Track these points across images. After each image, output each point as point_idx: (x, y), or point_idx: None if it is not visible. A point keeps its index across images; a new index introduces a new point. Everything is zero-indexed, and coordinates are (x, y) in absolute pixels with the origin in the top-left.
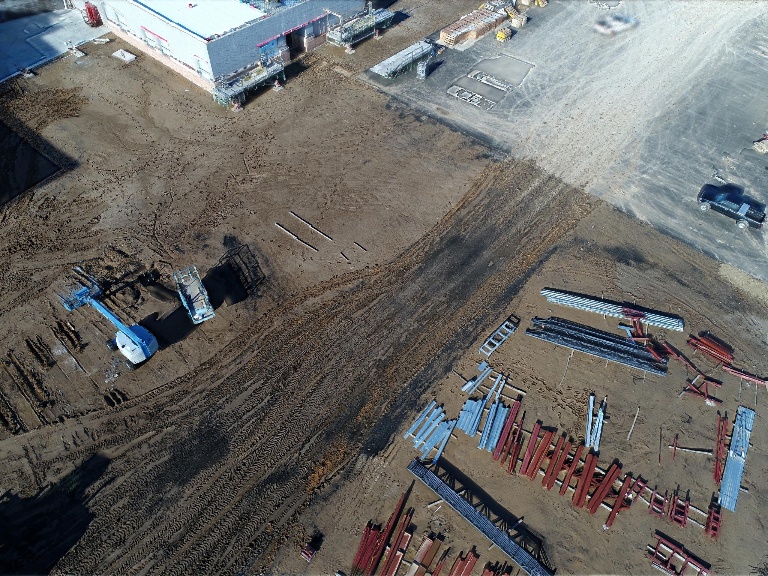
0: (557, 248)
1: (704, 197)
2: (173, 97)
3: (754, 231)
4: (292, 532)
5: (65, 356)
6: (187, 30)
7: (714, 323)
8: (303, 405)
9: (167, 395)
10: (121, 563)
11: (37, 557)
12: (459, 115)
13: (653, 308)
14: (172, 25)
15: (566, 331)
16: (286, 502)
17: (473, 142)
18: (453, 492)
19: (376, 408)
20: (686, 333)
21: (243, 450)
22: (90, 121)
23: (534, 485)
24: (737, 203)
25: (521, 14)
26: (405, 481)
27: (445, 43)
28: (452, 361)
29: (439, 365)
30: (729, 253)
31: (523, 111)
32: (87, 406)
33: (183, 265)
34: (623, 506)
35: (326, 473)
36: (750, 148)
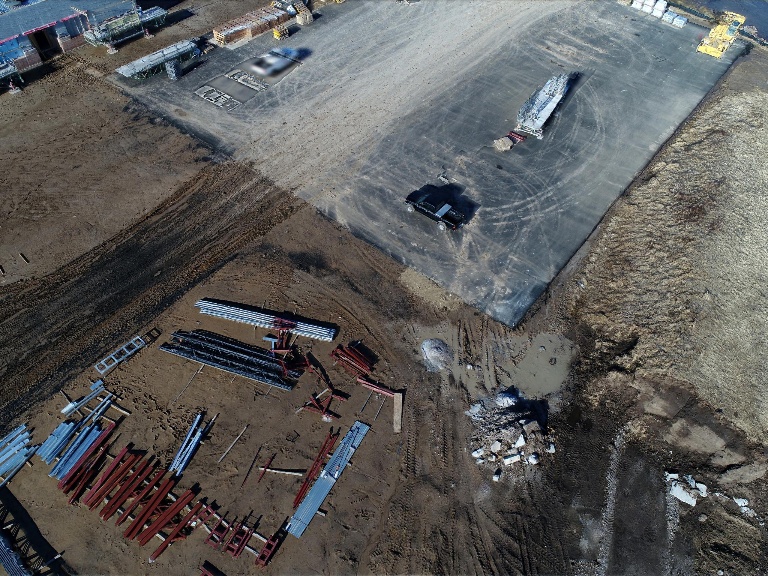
0: (237, 255)
1: (408, 198)
2: None
3: (456, 233)
4: None
5: None
6: None
7: (371, 332)
8: None
9: None
10: None
11: None
12: (196, 116)
13: (312, 317)
14: None
15: (203, 345)
16: None
17: (198, 144)
18: None
19: None
20: (335, 343)
21: None
22: None
23: (92, 516)
24: (434, 204)
25: (313, 11)
26: None
27: (217, 42)
28: (65, 381)
29: (49, 385)
30: (419, 257)
31: (266, 111)
32: None
33: None
34: (179, 536)
35: None
36: (490, 146)
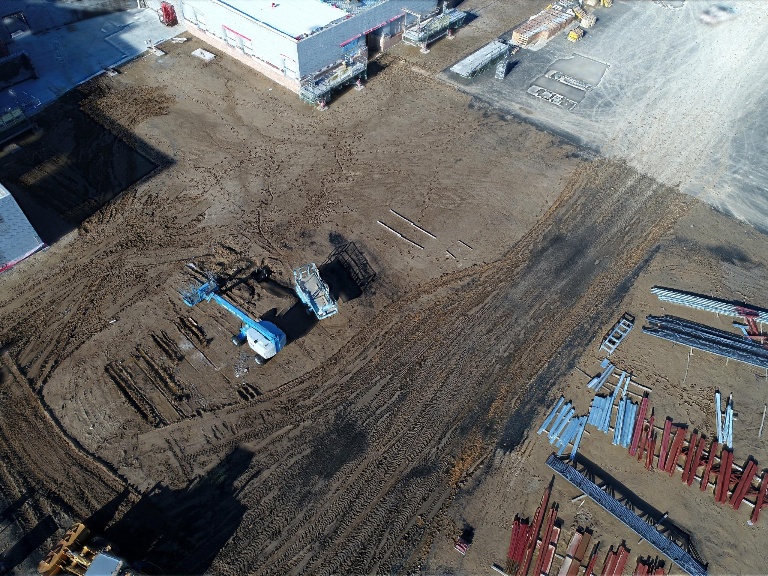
0: (660, 247)
1: None
2: (258, 96)
3: None
4: (442, 525)
5: (192, 351)
6: (275, 29)
7: None
8: (433, 400)
9: (298, 390)
10: (280, 554)
11: (197, 548)
12: (543, 115)
13: (764, 307)
14: (259, 24)
15: (682, 329)
16: (432, 496)
17: (561, 141)
18: (597, 487)
19: (506, 404)
20: None
21: (382, 444)
22: (180, 119)
23: (673, 481)
24: None
25: (588, 14)
26: (545, 476)
27: (518, 43)
28: (574, 358)
29: (561, 362)
30: None
31: (606, 111)
32: (222, 400)
33: (293, 262)
34: (765, 502)
35: (466, 467)
36: None
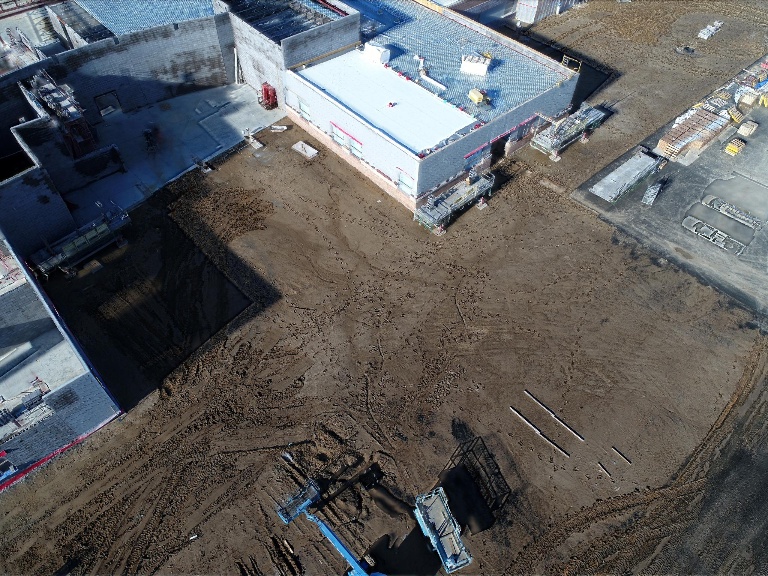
0: None
1: None
2: (365, 210)
3: None
4: None
5: None
6: (394, 141)
7: None
8: None
9: None
10: None
11: None
12: (705, 261)
13: None
14: (376, 132)
15: None
16: None
17: (730, 303)
18: None
19: None
20: None
21: None
22: (277, 237)
23: None
24: None
25: (745, 117)
26: None
27: (665, 154)
28: None
29: None
30: None
31: None
32: None
33: (408, 461)
34: None
35: None
36: None
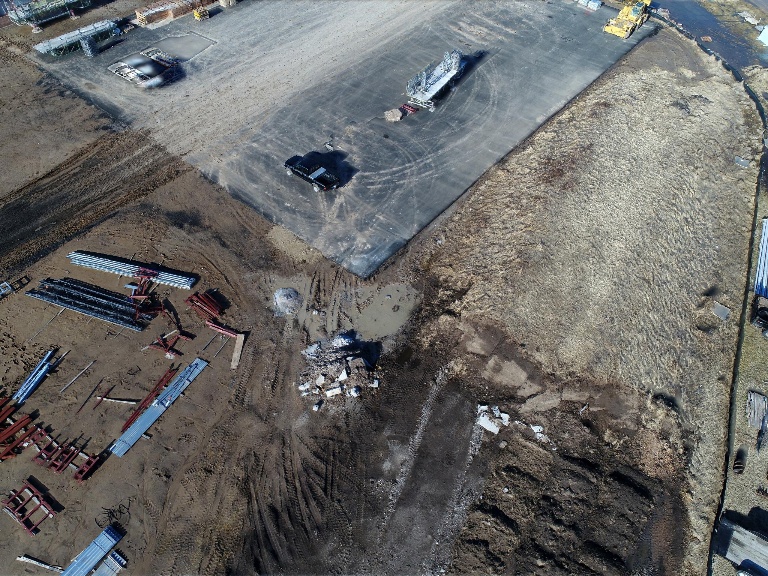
0: (117, 213)
1: (286, 162)
2: None
3: (329, 195)
4: None
5: None
6: None
7: (229, 281)
8: None
9: None
10: None
11: None
12: (104, 89)
13: (177, 268)
14: None
15: (67, 291)
16: None
17: (101, 115)
18: None
19: None
20: (193, 291)
21: None
22: None
23: None
24: (307, 167)
25: None
26: None
27: (139, 22)
28: None
29: None
30: (289, 215)
31: (172, 85)
32: None
33: None
34: (10, 454)
35: None
36: (381, 117)
